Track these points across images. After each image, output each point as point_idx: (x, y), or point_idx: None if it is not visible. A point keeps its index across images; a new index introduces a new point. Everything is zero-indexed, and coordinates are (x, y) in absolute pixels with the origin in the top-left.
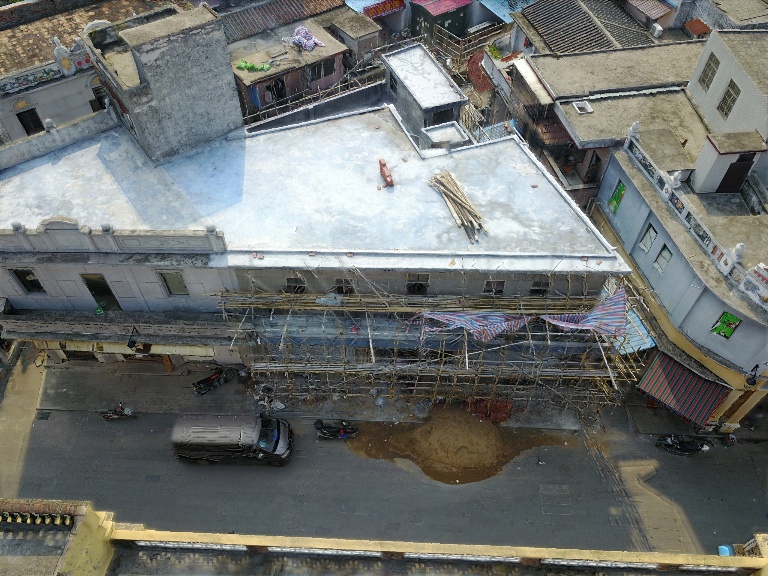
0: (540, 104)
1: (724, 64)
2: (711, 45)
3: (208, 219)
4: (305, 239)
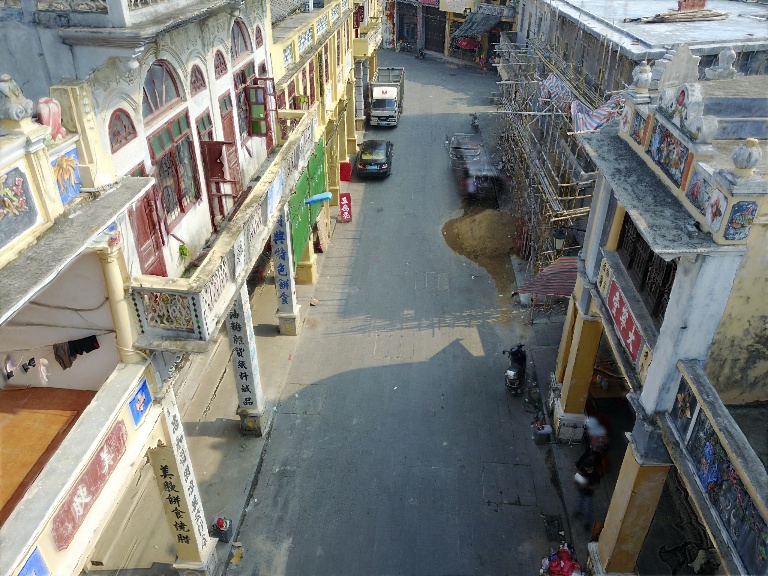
0: None
1: None
2: None
3: None
4: (581, 2)
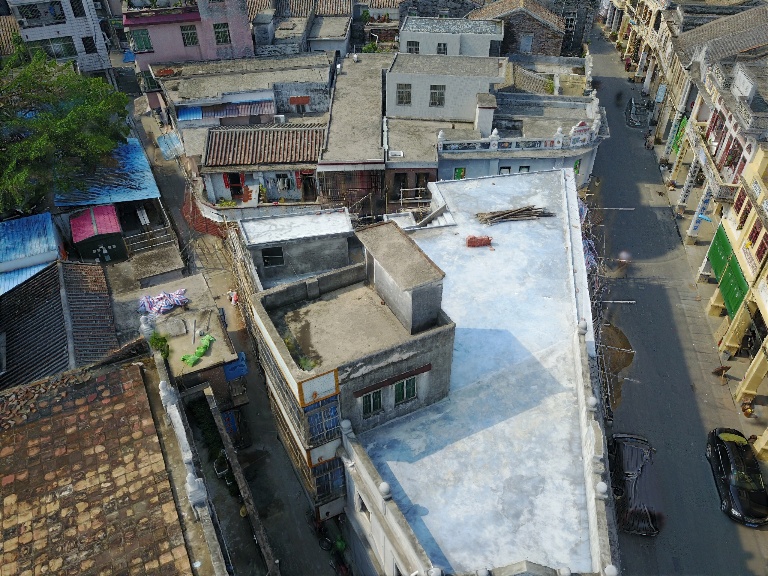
0: (382, 171)
1: (416, 82)
2: (393, 81)
3: (536, 353)
4: (559, 293)
